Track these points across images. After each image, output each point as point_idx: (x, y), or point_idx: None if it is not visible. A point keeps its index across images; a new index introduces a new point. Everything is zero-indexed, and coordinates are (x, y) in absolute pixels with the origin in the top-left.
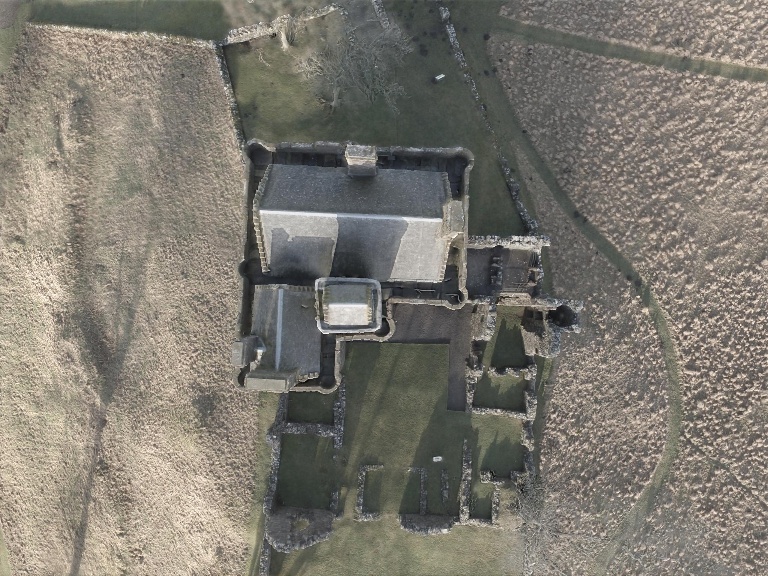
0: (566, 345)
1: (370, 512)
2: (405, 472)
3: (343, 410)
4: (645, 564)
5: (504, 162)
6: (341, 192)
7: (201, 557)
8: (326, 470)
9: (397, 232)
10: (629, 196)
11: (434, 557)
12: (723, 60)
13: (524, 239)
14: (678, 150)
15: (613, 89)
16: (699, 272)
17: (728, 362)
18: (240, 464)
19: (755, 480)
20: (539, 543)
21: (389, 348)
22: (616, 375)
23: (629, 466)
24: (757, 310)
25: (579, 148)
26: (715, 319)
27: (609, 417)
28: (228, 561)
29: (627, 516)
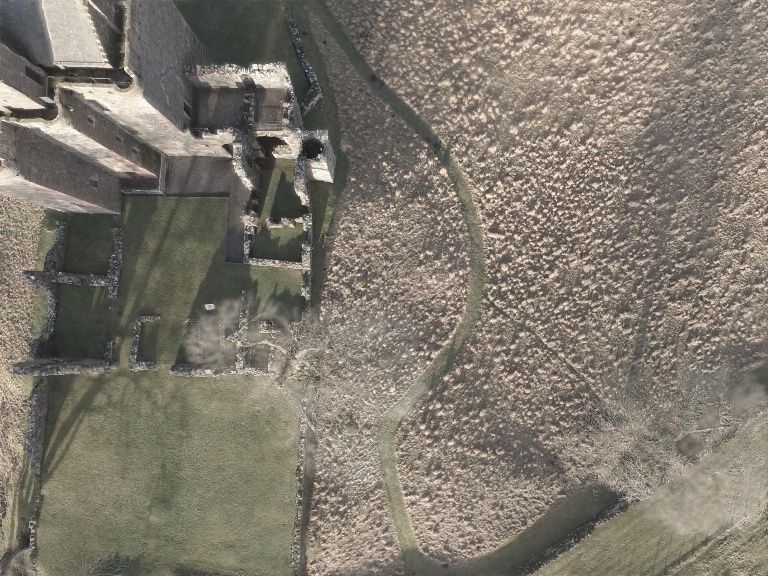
0: (349, 199)
1: (145, 361)
2: (182, 323)
3: (119, 262)
4: (441, 422)
5: (291, 22)
6: None
7: None
8: (102, 321)
9: None
10: (429, 60)
11: (213, 407)
12: None
13: (263, 67)
14: (482, 16)
15: None
16: (503, 136)
17: (534, 226)
18: (19, 318)
19: (561, 342)
20: (321, 394)
21: (166, 201)
22: (409, 234)
23: (426, 326)
24: (566, 175)
25: (376, 13)
26: (520, 183)
27: (402, 275)
28: (10, 414)
29: (422, 374)
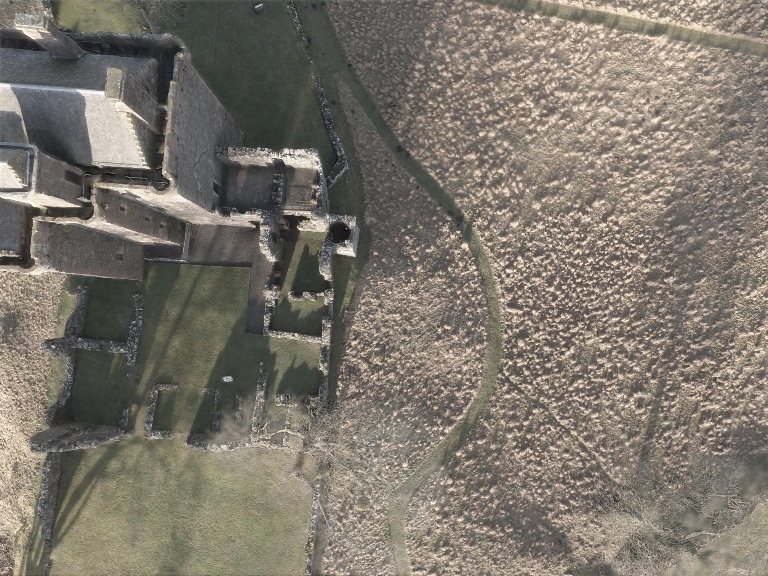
0: (371, 273)
1: (160, 430)
2: (199, 393)
3: (139, 329)
4: (451, 498)
5: (320, 92)
6: (31, 69)
7: (6, 475)
8: (119, 387)
9: (77, 107)
10: (455, 133)
11: (226, 478)
12: (560, 1)
13: (294, 152)
14: (510, 89)
15: (445, 27)
16: (526, 211)
17: (552, 302)
18: (36, 380)
19: (574, 420)
20: (334, 469)
21: (189, 269)
22: (429, 308)
23: (441, 400)
24: (586, 252)
25: (405, 83)
26: (540, 259)
27: (419, 349)
28: (22, 476)
29: (435, 449)
